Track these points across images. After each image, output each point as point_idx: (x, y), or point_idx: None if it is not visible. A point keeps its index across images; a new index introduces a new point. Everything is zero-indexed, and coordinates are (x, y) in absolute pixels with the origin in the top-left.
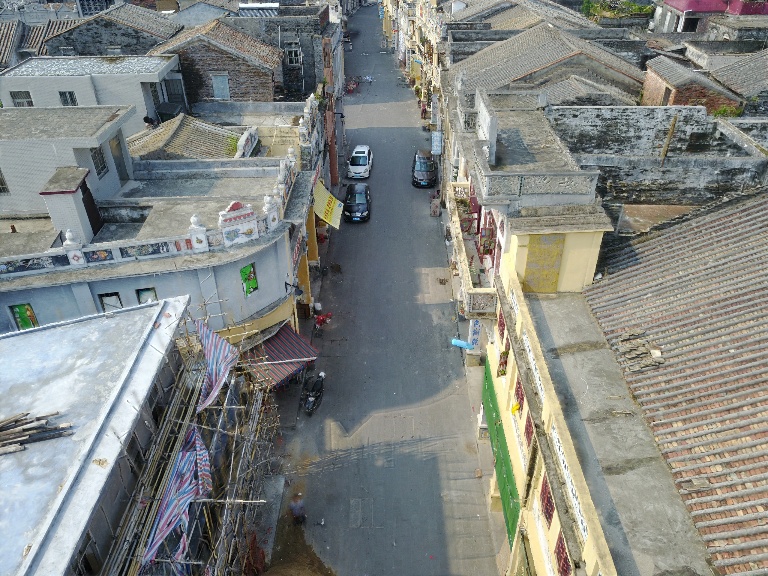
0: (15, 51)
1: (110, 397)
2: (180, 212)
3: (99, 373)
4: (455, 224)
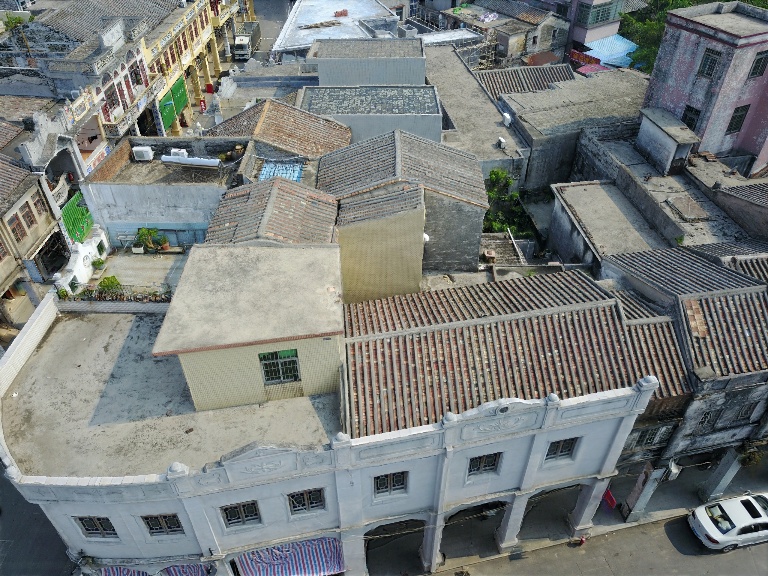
0: (623, 276)
1: (289, 31)
2: (282, 73)
3: (295, 35)
4: (139, 99)
